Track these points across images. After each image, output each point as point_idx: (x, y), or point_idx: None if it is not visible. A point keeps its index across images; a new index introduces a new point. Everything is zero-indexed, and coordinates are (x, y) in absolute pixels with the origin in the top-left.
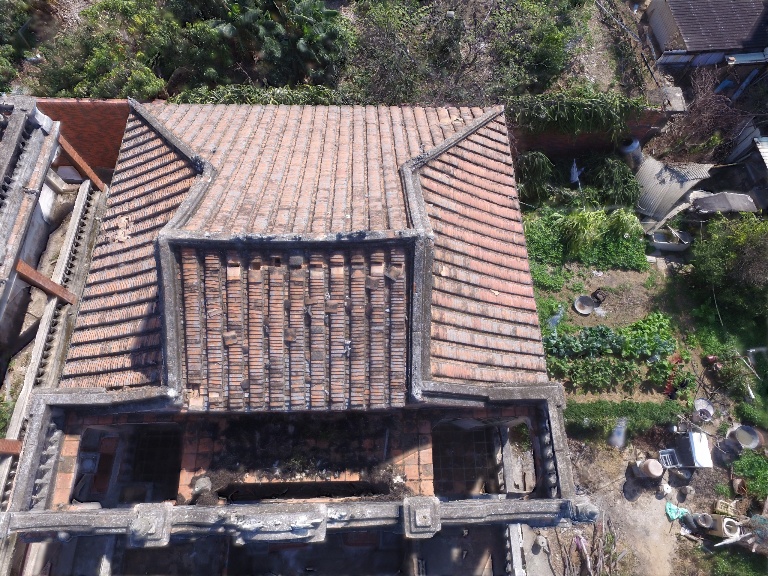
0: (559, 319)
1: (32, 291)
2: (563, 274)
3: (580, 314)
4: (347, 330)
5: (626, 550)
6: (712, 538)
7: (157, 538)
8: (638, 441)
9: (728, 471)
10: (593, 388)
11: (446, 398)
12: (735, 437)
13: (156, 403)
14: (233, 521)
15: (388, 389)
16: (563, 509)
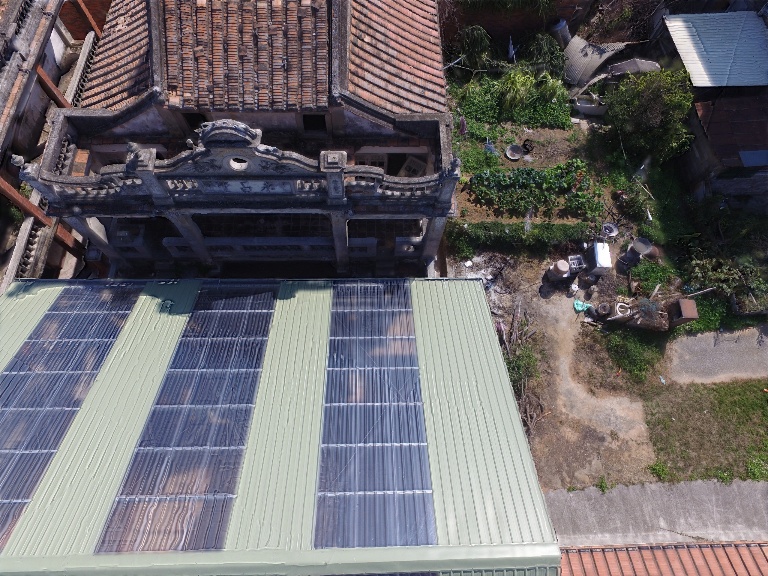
0: (492, 163)
1: (47, 115)
2: (498, 130)
3: (511, 160)
4: (285, 49)
5: (537, 331)
6: (609, 322)
7: (145, 164)
8: (554, 256)
9: (628, 277)
10: (518, 214)
11: (360, 110)
12: (633, 247)
13: (145, 106)
14: (198, 150)
15: (315, 94)
16: (441, 176)
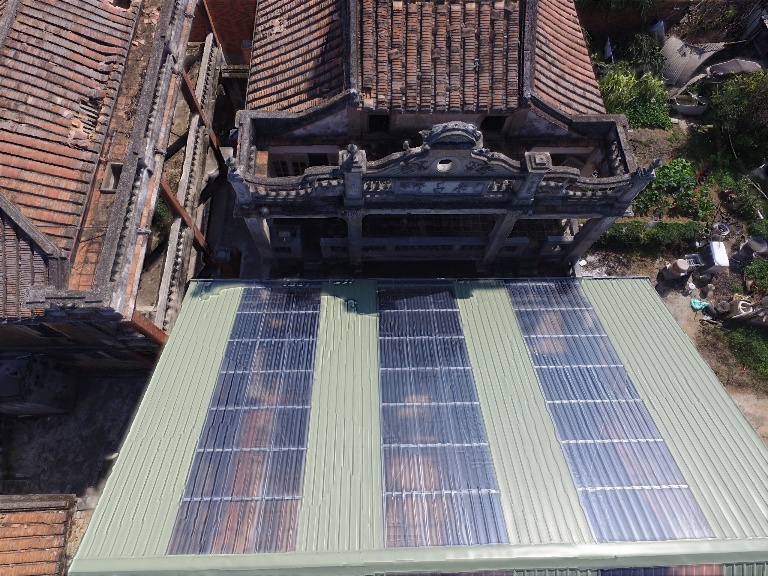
0: None
1: None
2: None
3: None
4: (476, 52)
5: None
6: (729, 320)
7: (359, 166)
8: (667, 255)
9: (742, 275)
10: None
11: (544, 111)
12: (747, 246)
13: (337, 108)
14: (413, 152)
15: (505, 96)
16: (633, 176)
